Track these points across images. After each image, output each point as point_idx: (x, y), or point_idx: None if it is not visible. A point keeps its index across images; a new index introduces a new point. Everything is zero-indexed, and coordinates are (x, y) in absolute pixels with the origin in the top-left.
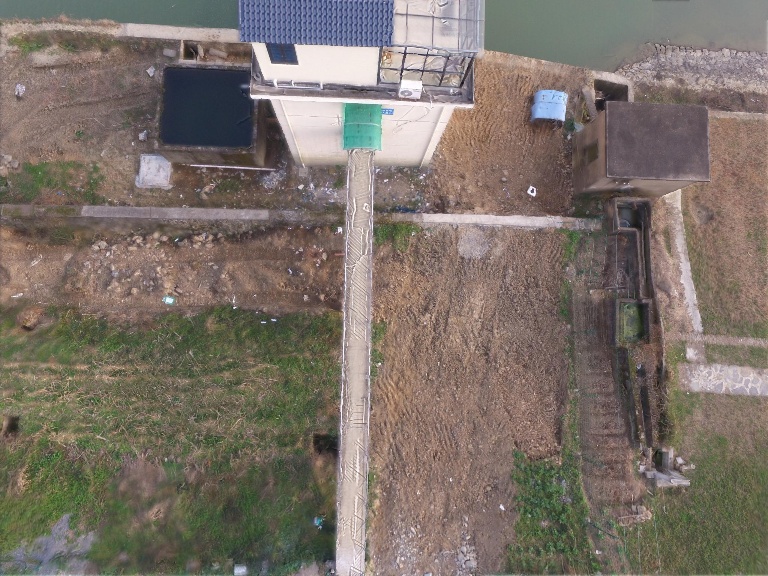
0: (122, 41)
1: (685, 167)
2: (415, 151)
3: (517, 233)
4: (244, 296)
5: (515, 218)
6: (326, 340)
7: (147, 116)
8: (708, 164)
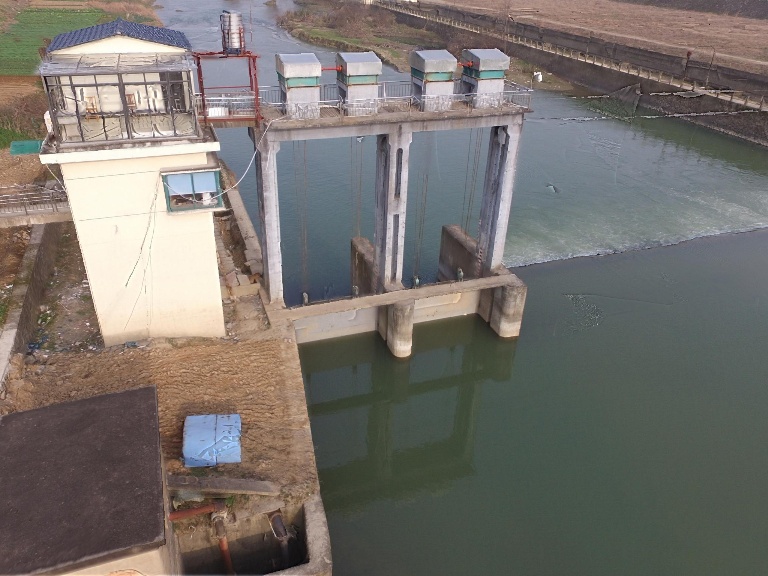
0: None
1: (1, 532)
2: None
3: None
4: None
5: None
6: None
7: None
8: None
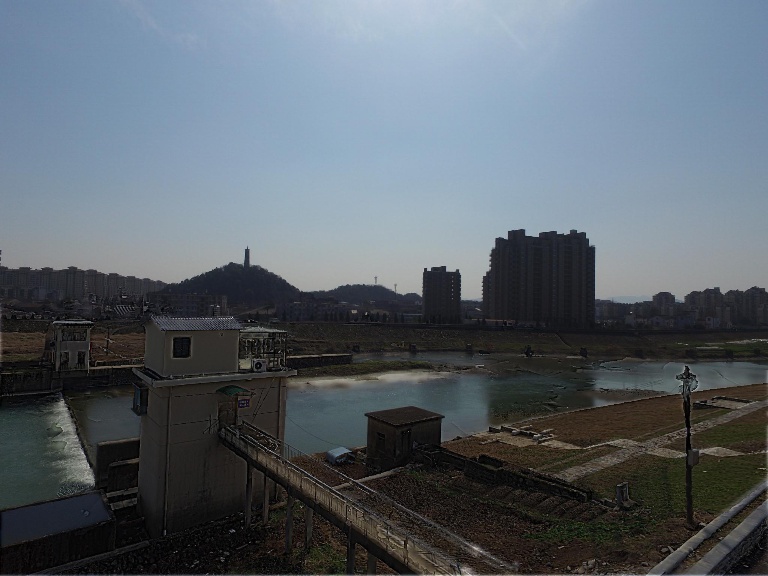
0: None
1: None
2: None
3: (377, 482)
4: None
5: (368, 477)
6: (275, 566)
7: None
8: None
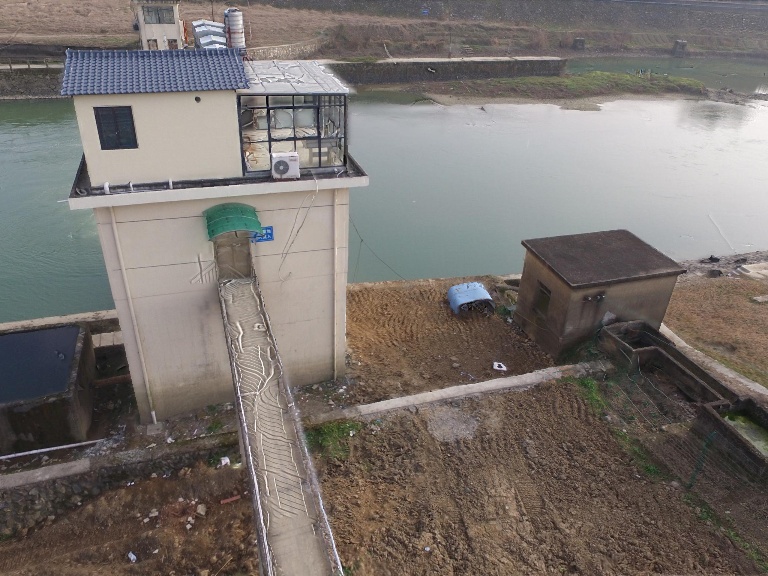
0: None
1: (649, 265)
2: (320, 334)
3: (508, 397)
4: None
5: (494, 381)
6: None
7: None
8: (670, 259)
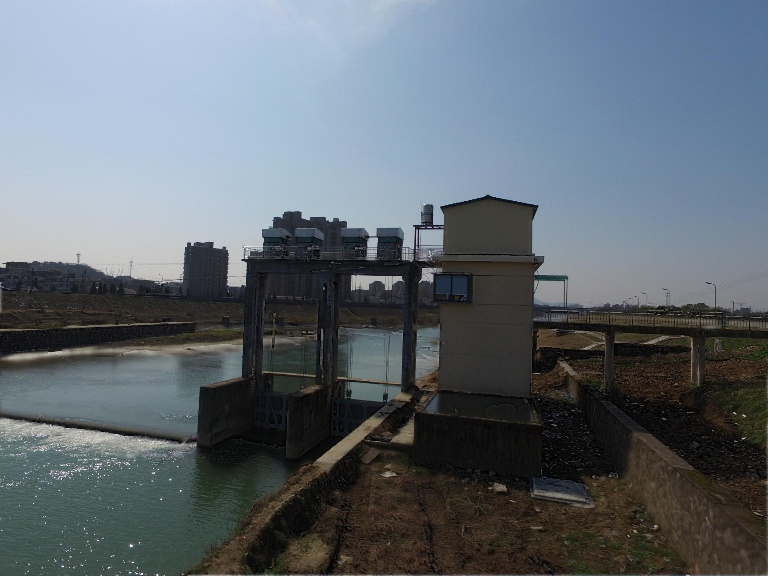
0: (331, 480)
1: None
2: None
3: None
4: (721, 436)
5: None
6: None
7: (466, 480)
8: None
